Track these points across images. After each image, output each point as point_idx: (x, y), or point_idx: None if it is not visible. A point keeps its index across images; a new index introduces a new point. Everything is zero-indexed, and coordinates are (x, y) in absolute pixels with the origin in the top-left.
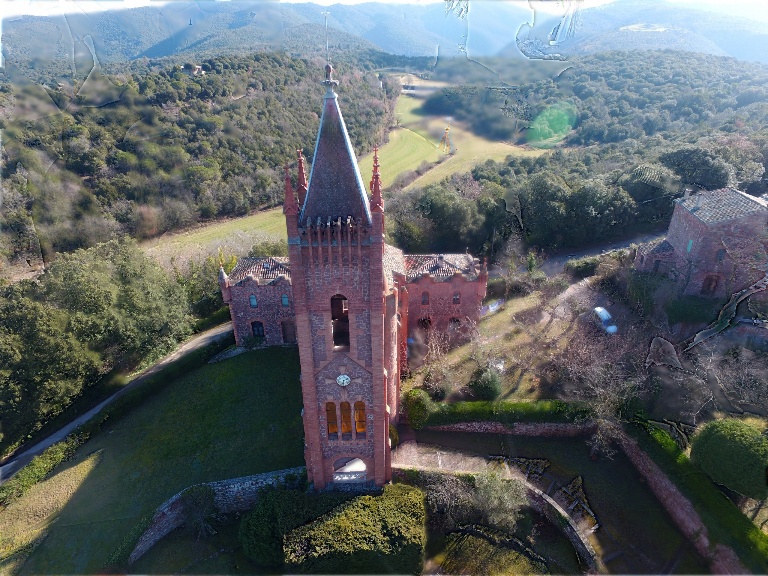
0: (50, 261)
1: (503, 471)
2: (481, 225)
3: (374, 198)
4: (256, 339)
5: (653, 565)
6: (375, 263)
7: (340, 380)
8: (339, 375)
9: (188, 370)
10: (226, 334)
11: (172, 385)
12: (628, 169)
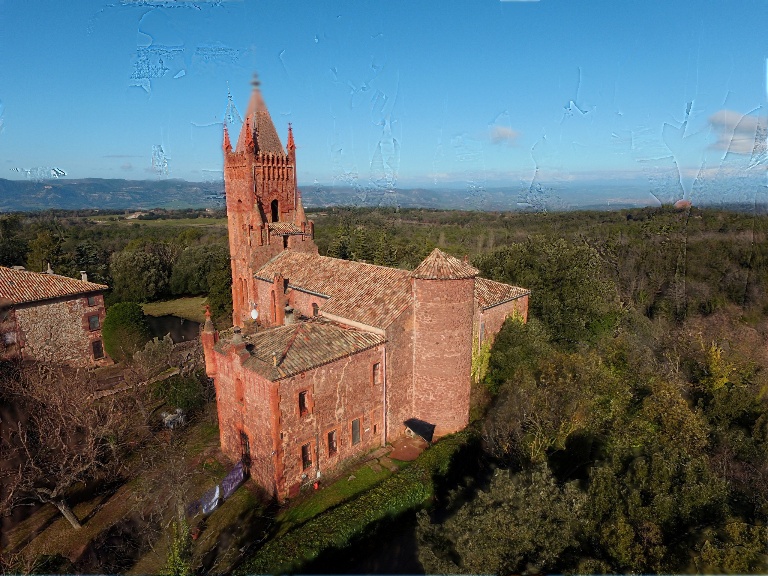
0: (752, 307)
1: None
2: None
3: None
4: None
5: None
6: None
7: None
8: None
9: None
10: None
11: None
12: None
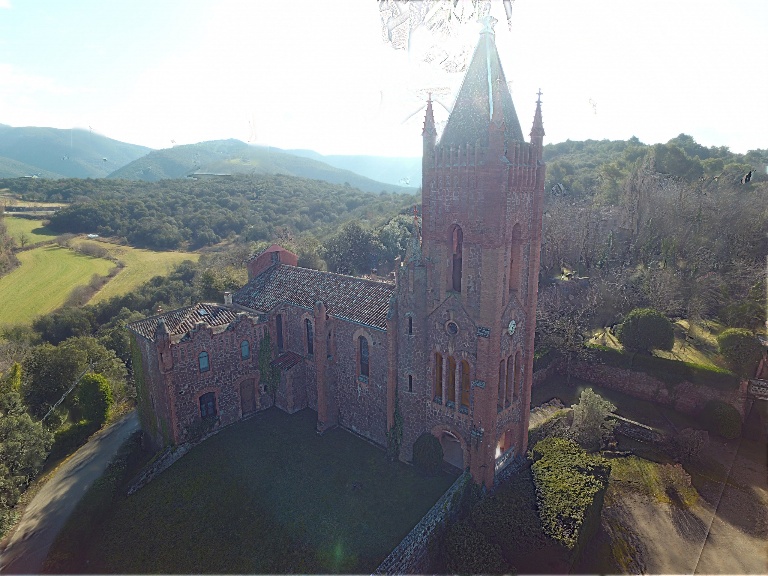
0: None
1: (551, 414)
2: (327, 269)
3: (540, 123)
4: (206, 422)
5: (661, 422)
6: (541, 186)
7: (510, 328)
8: (510, 322)
9: (98, 520)
10: (118, 451)
11: (94, 550)
12: (377, 226)
